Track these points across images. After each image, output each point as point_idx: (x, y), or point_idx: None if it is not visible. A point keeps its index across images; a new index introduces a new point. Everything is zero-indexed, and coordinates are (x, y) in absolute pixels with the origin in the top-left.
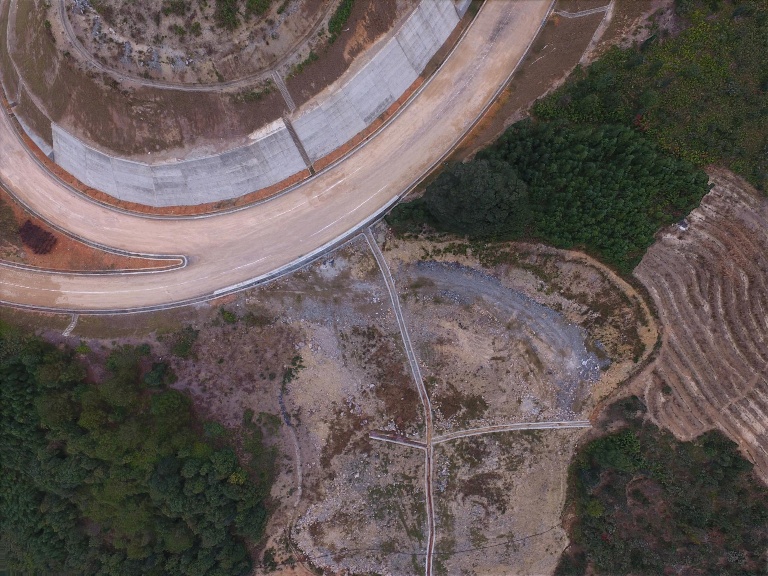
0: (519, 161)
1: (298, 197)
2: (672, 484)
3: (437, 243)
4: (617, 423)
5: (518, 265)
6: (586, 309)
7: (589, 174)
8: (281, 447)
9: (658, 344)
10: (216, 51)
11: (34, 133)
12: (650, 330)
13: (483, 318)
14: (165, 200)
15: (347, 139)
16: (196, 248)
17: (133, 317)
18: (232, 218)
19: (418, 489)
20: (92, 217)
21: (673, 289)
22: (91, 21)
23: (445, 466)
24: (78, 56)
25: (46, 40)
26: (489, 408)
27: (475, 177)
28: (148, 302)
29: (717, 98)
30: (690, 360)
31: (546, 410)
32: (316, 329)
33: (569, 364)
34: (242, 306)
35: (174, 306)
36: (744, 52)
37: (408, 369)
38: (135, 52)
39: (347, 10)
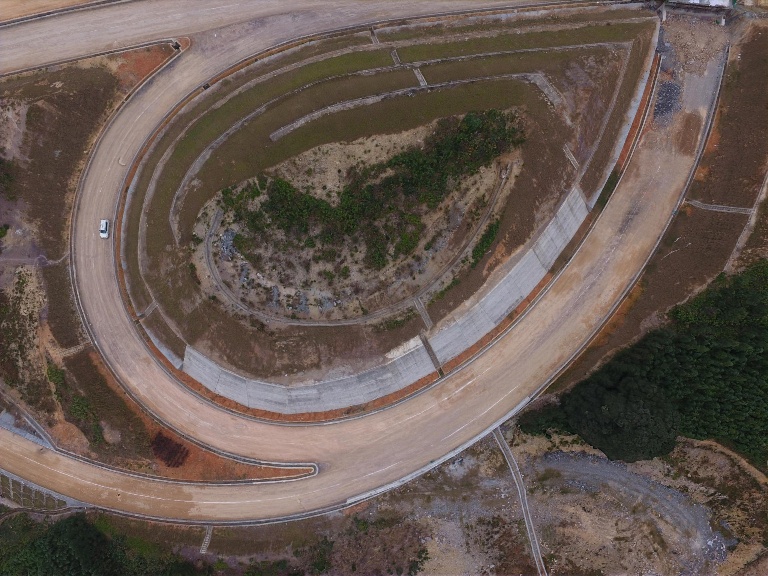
0: None
1: (427, 400)
2: None
3: (565, 436)
4: None
5: None
6: (713, 492)
7: (731, 380)
8: None
9: None
10: (363, 289)
11: (163, 345)
12: None
13: (608, 503)
14: (296, 409)
15: (476, 340)
16: (326, 455)
17: (267, 529)
18: (361, 423)
19: None
20: (221, 425)
21: None
22: (239, 267)
23: None
24: (224, 299)
25: (189, 279)
26: None
27: (638, 426)
28: (281, 512)
29: None
30: None
31: None
32: (443, 524)
33: (694, 544)
34: (375, 514)
35: (307, 516)
36: None
37: (529, 549)
38: (283, 296)
39: (492, 238)
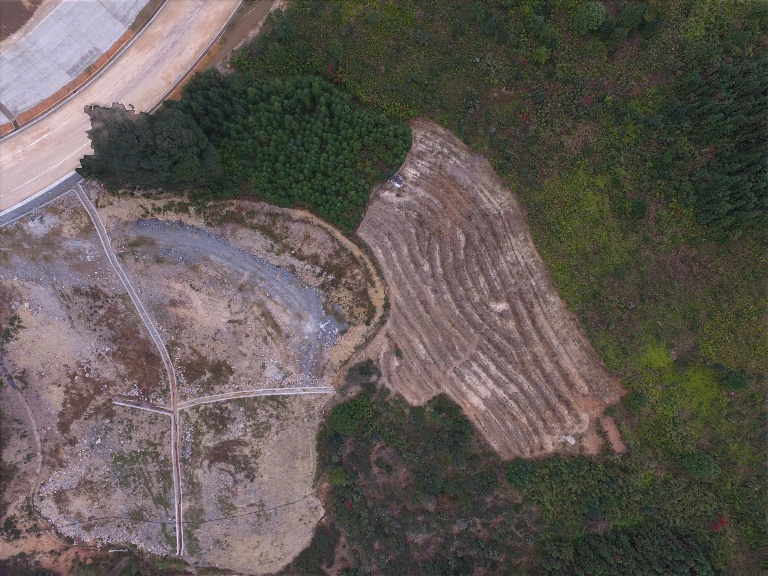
0: (209, 112)
1: (1, 151)
2: (407, 450)
3: (154, 200)
4: (356, 388)
5: (245, 224)
6: (320, 271)
7: (287, 127)
8: (7, 410)
9: (386, 306)
10: None
11: None
12: (377, 291)
13: (212, 279)
14: None
15: (51, 92)
16: None
17: None
18: None
19: (163, 456)
20: None
21: (396, 249)
22: None
23: (189, 432)
24: None
25: None
26: (235, 373)
27: (112, 120)
28: None
29: (408, 47)
30: (416, 322)
31: (290, 375)
32: (30, 288)
33: (306, 327)
34: None
35: None
36: None
37: (145, 332)
38: None
39: None
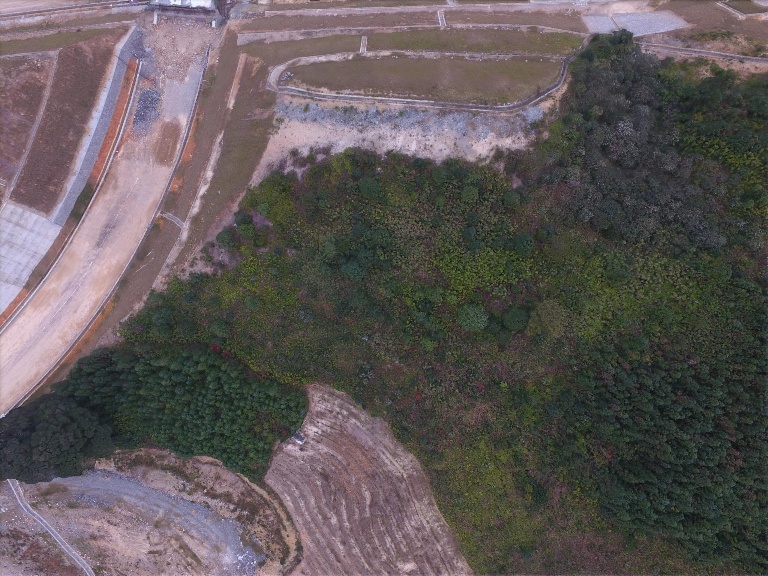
0: None
1: None
2: None
3: None
4: None
5: (155, 467)
6: (233, 507)
7: None
8: None
9: (298, 549)
10: None
11: None
12: (289, 535)
13: (128, 518)
14: None
15: None
16: None
17: None
18: None
19: None
20: None
21: (303, 498)
22: None
23: None
24: None
25: None
26: None
27: None
28: None
29: (294, 325)
30: (328, 568)
31: None
32: None
33: (225, 559)
34: None
35: None
36: (309, 282)
37: (70, 561)
38: None
39: None
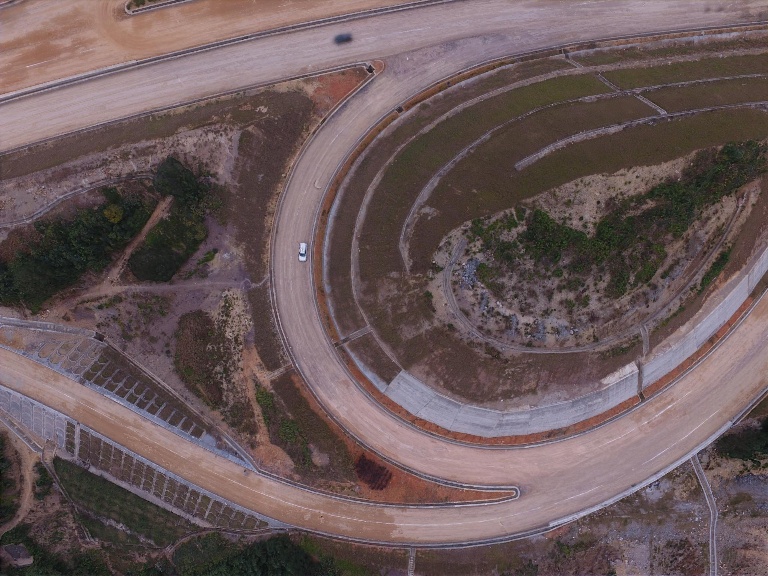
0: None
1: (627, 423)
2: None
3: (759, 460)
4: None
5: None
6: None
7: None
8: None
9: None
10: (598, 317)
11: (368, 369)
12: None
13: None
14: (499, 433)
15: (678, 364)
16: (527, 478)
17: (471, 552)
18: (561, 446)
19: None
20: (421, 447)
21: None
22: (479, 295)
23: None
24: (461, 327)
25: (421, 306)
26: None
27: None
28: (483, 534)
29: None
30: None
31: None
32: (635, 547)
33: None
34: (577, 537)
35: (510, 539)
36: None
37: (707, 571)
38: (522, 324)
39: (723, 266)
